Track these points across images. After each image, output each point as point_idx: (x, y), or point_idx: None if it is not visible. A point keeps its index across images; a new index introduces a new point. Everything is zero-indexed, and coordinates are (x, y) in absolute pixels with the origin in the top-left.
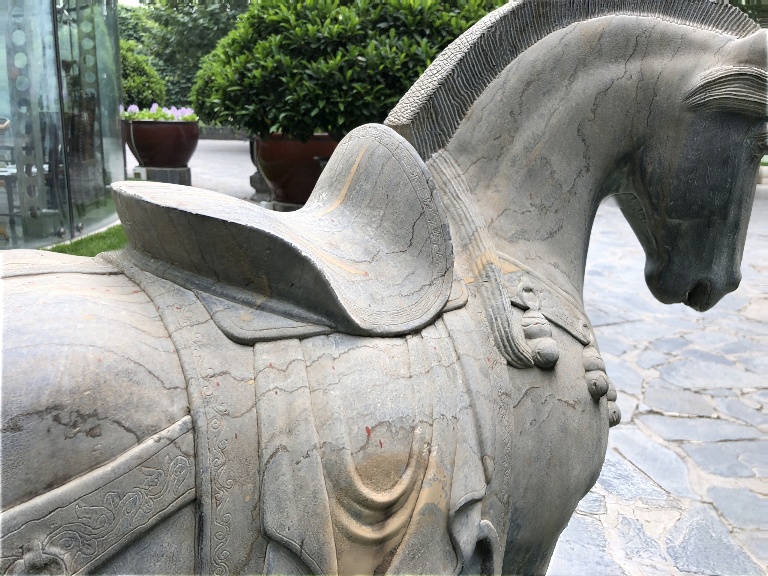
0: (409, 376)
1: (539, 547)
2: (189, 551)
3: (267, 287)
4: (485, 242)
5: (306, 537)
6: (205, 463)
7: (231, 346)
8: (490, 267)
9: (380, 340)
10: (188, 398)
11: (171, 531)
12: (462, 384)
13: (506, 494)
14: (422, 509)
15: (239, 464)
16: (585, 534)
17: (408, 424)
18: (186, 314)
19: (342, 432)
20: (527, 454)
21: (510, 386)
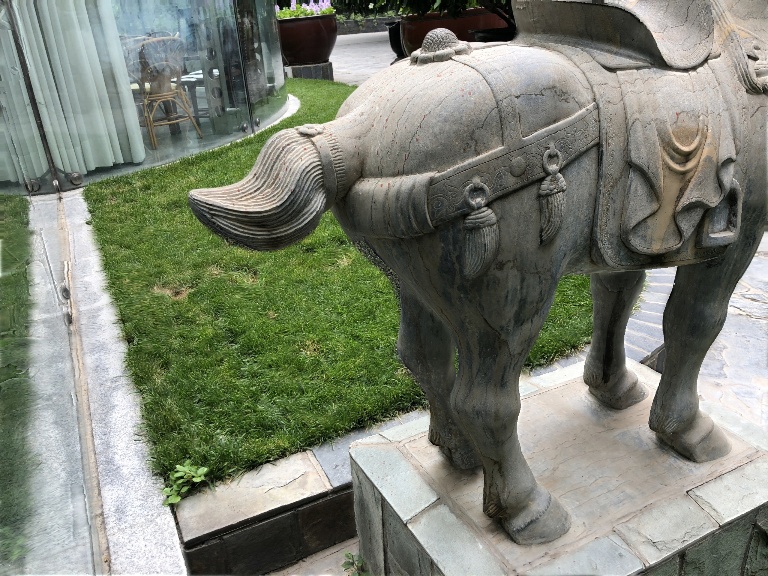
0: (693, 91)
1: (761, 210)
2: (596, 169)
3: (619, 43)
4: (729, 19)
5: (651, 163)
6: (604, 125)
7: (606, 72)
8: (734, 34)
9: (676, 73)
10: (594, 94)
11: (589, 157)
12: (722, 98)
13: (745, 168)
14: (705, 159)
15: (618, 127)
16: (760, 331)
17: (696, 114)
18: (582, 58)
19: (665, 114)
20: (758, 146)
21: (748, 105)
